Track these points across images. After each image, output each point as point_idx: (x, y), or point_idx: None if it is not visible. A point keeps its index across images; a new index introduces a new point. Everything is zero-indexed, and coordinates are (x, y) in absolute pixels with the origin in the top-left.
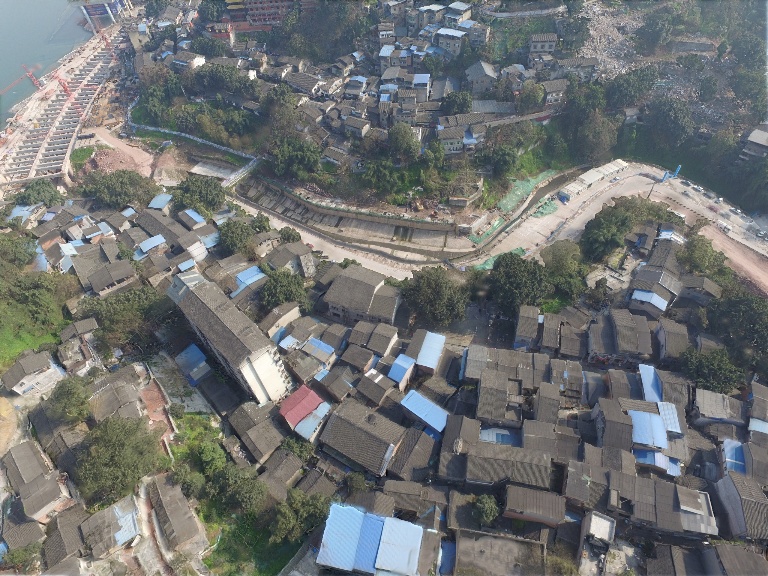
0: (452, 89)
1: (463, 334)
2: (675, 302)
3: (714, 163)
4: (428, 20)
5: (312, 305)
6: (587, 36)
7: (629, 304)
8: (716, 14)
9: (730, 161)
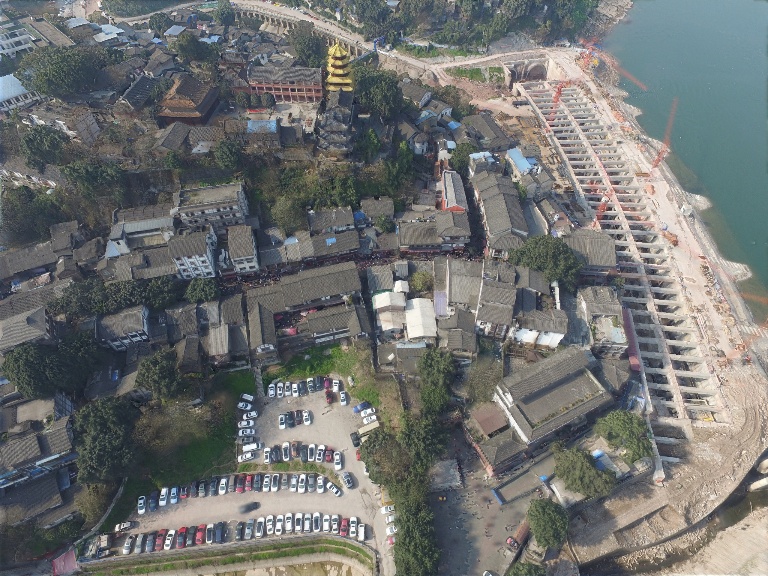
0: None
1: None
2: None
3: None
4: None
5: None
6: None
7: None
8: None
9: None
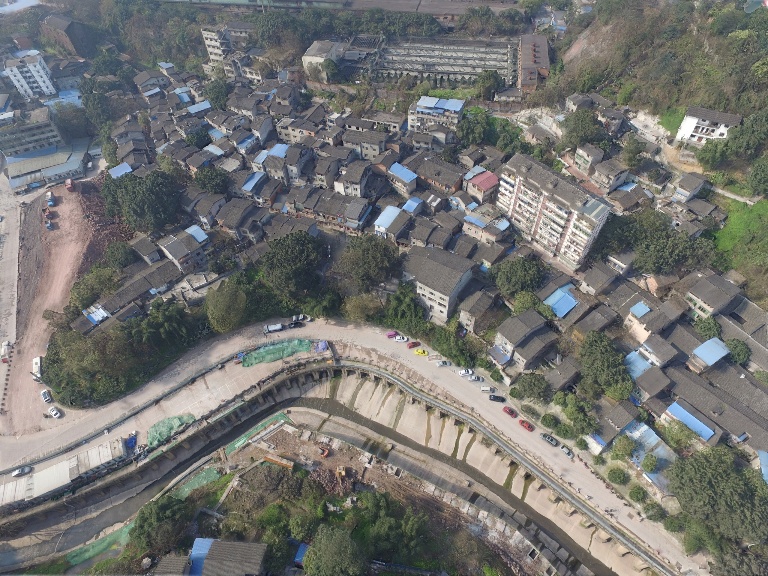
0: None
1: None
2: None
3: None
4: None
5: None
6: None
7: None
8: None
9: None
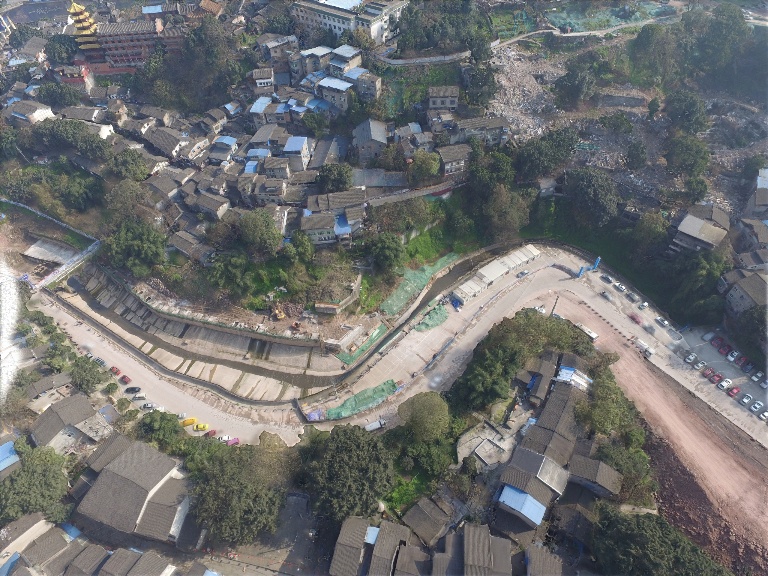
0: (337, 153)
1: (276, 547)
2: (563, 492)
3: (641, 253)
4: (313, 66)
5: (68, 511)
6: (495, 90)
7: (498, 504)
8: (650, 60)
9: (659, 251)
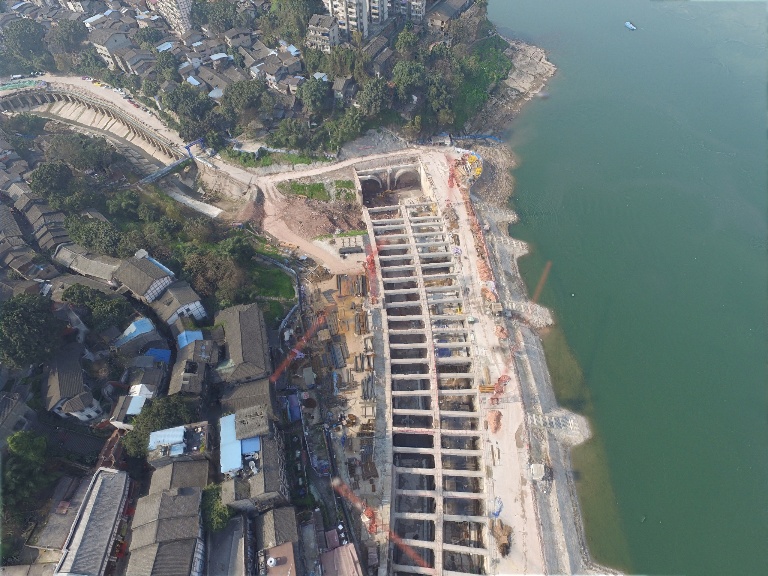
0: None
1: None
2: None
3: None
4: None
5: None
6: None
7: None
8: None
9: None
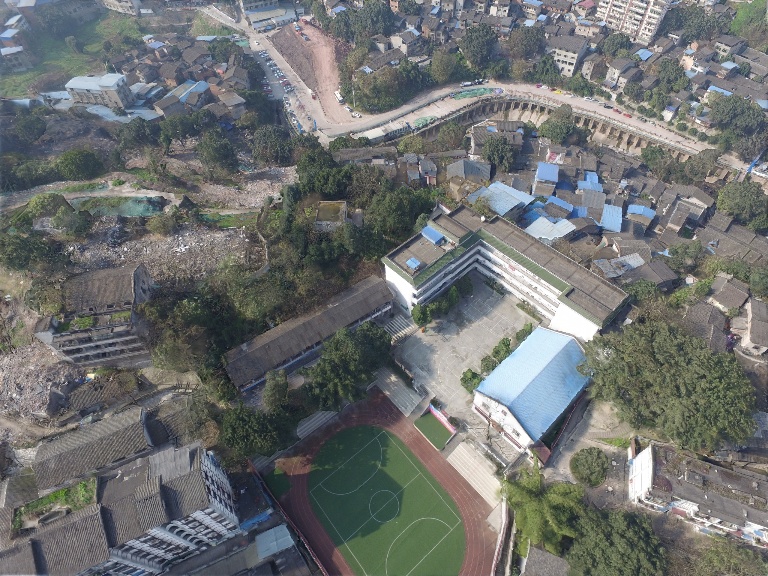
0: None
1: None
2: None
3: None
4: None
5: None
6: None
7: None
8: None
9: None
